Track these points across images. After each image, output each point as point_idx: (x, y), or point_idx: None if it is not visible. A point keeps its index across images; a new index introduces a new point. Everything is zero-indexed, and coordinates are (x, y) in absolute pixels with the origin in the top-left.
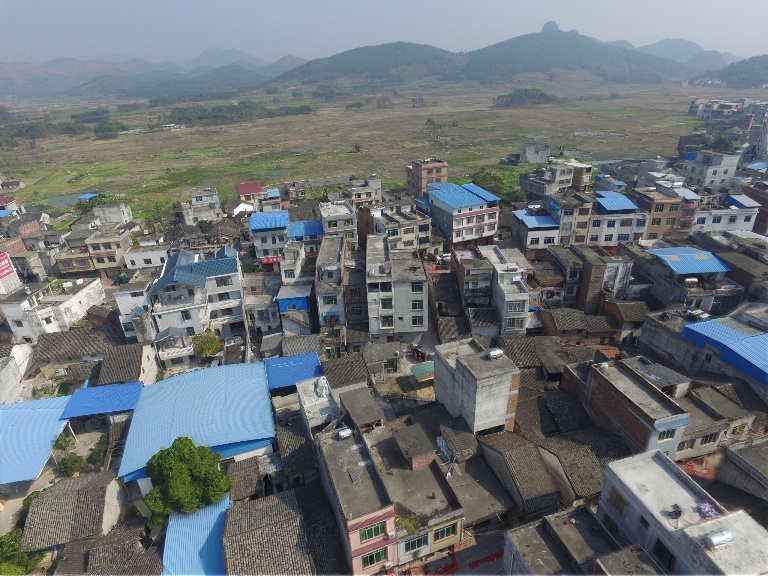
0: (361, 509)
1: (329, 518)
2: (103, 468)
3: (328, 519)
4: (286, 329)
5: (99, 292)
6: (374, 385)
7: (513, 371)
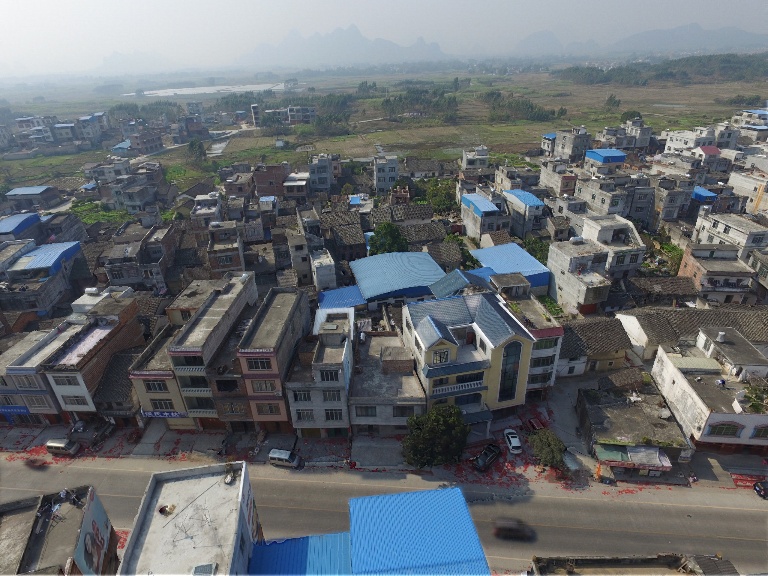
0: (308, 211)
1: None
2: (448, 269)
3: None
4: None
5: (697, 421)
6: None
7: None
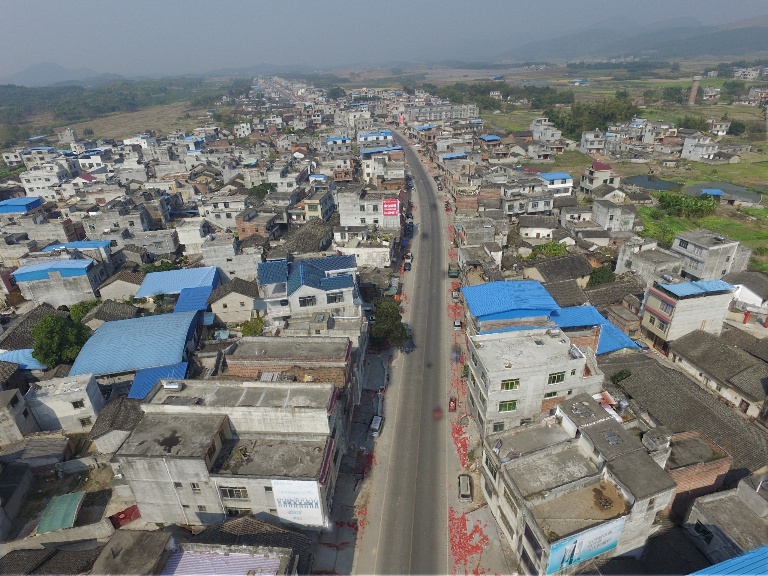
0: None
1: None
2: None
3: None
4: None
5: (384, 259)
6: (94, 455)
7: None
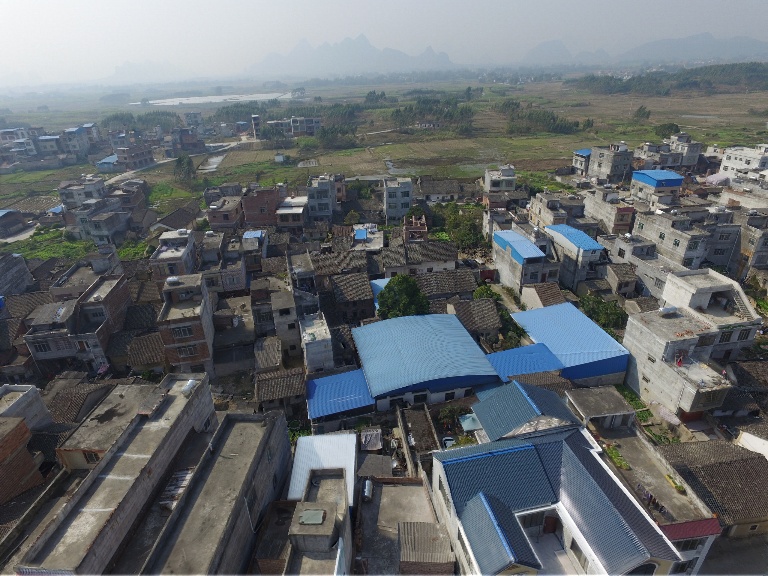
0: None
1: (318, 292)
2: (483, 339)
3: (319, 292)
4: None
5: None
6: None
7: None
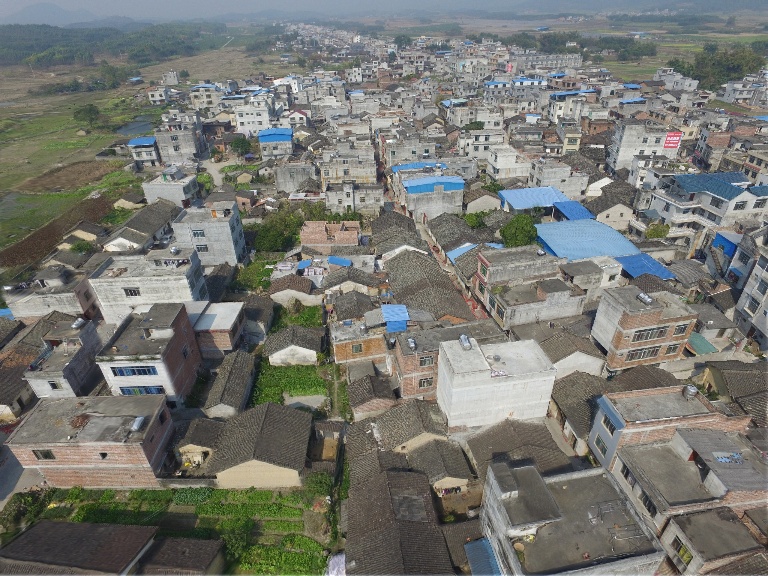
0: (490, 260)
1: None
2: None
3: None
4: (707, 263)
5: None
6: None
7: (625, 307)
